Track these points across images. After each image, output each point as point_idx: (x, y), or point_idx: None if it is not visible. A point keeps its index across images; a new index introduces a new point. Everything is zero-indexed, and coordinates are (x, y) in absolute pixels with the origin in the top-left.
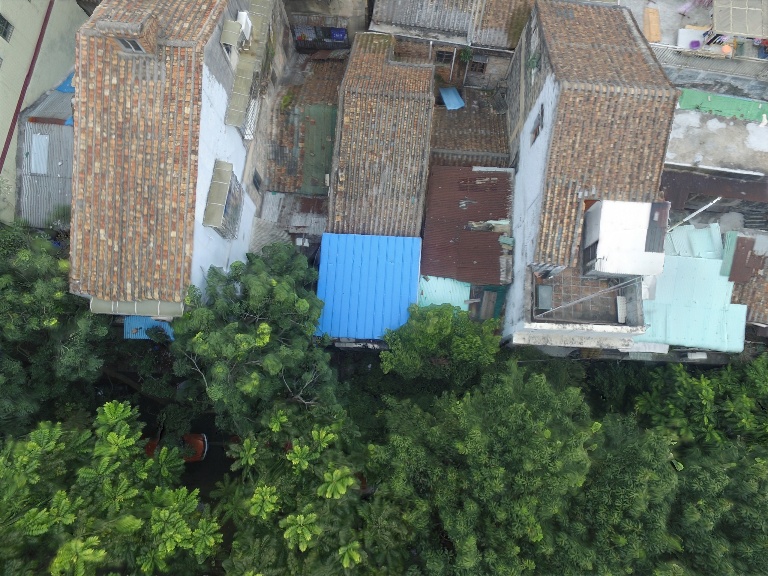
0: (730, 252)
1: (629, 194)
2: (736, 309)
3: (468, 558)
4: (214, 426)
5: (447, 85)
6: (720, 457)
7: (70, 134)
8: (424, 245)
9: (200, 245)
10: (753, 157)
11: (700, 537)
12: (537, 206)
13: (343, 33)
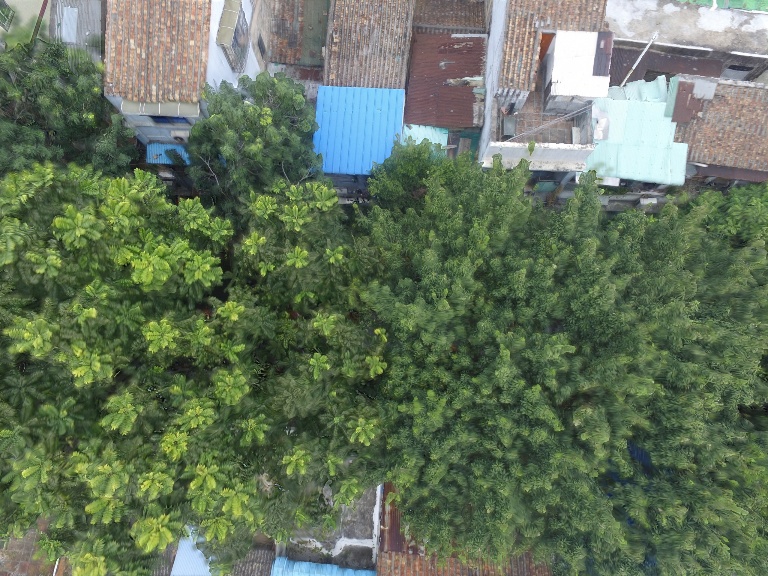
0: (673, 95)
1: (579, 24)
2: (678, 147)
3: (429, 252)
4: None
5: None
6: None
7: (97, 7)
8: (408, 99)
9: (213, 60)
10: (703, 35)
11: None
12: (501, 38)
13: None
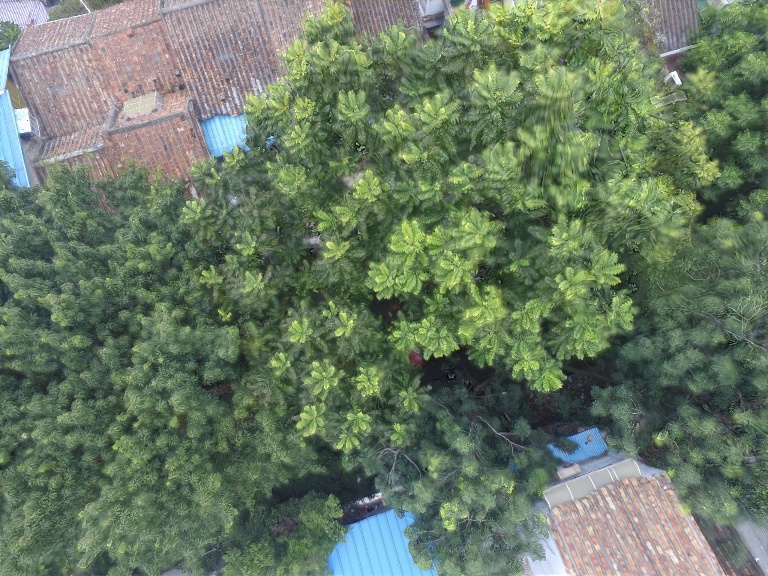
0: None
1: None
2: None
3: (176, 403)
4: (474, 372)
5: None
6: None
7: None
8: None
9: None
10: None
11: None
12: None
13: None
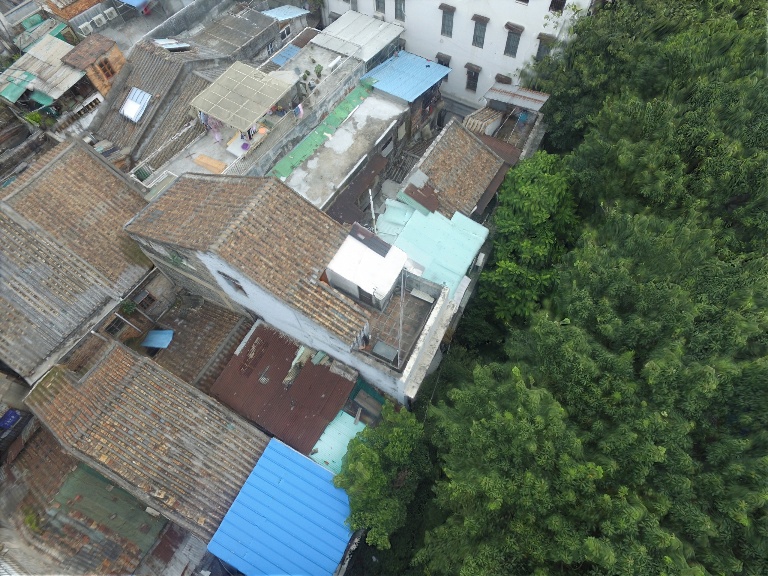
0: (412, 202)
1: (333, 246)
2: (456, 219)
3: (606, 555)
4: None
5: (143, 337)
6: (565, 286)
7: None
8: (281, 438)
9: None
10: (350, 154)
11: (625, 332)
12: (303, 319)
13: (12, 414)
